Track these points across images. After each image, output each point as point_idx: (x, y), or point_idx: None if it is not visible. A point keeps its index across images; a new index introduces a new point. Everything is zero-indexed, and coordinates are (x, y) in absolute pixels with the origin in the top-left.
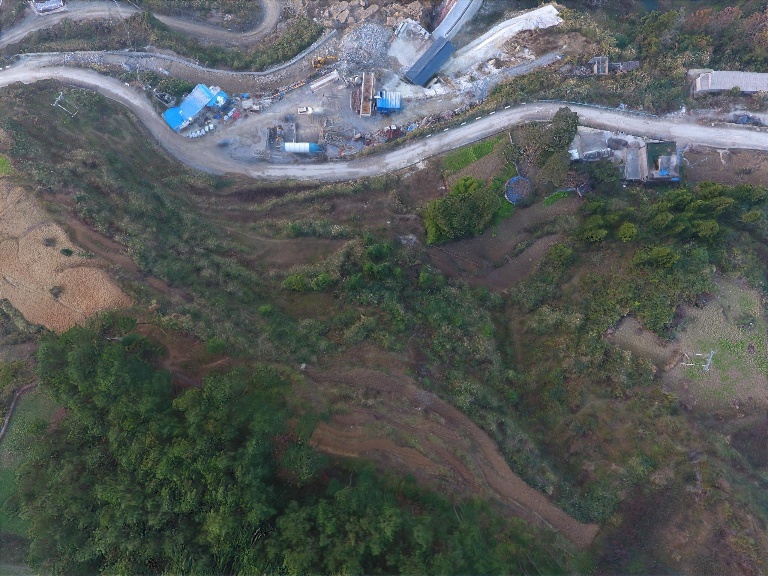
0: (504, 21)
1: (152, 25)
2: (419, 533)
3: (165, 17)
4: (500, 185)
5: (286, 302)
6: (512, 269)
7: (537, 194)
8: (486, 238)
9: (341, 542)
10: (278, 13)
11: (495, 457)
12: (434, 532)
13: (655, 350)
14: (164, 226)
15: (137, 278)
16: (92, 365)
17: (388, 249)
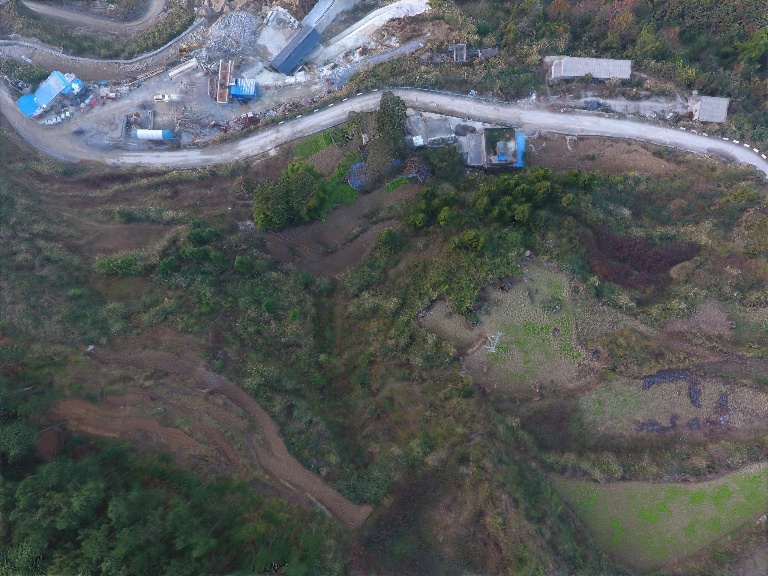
0: (376, 10)
1: (20, 13)
2: (114, 508)
3: (47, 7)
4: (344, 171)
5: (103, 286)
6: (345, 254)
7: (380, 180)
8: (325, 224)
9: (29, 516)
10: (164, 3)
11: (274, 438)
12: (138, 507)
13: (462, 333)
14: None
15: None
16: None
17: (212, 234)
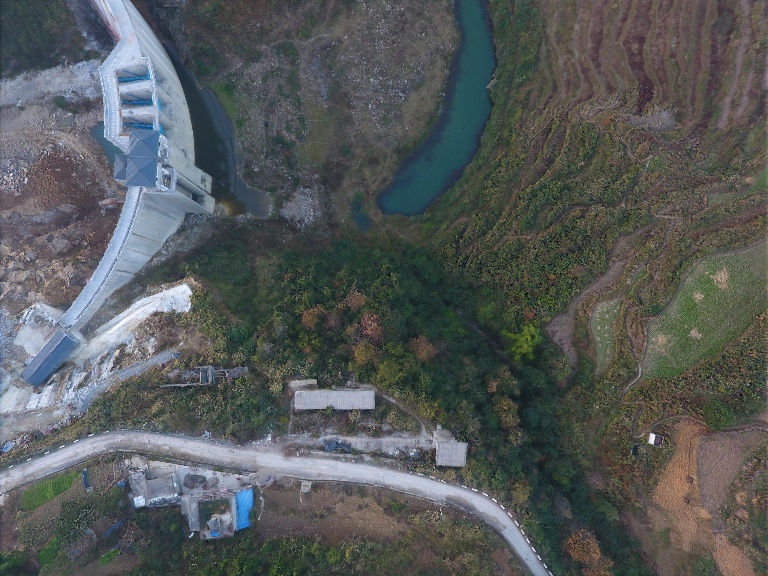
0: (143, 298)
1: None
2: None
3: None
4: None
5: None
6: None
7: (97, 548)
8: None
9: None
10: None
11: None
12: None
13: None
14: None
15: None
16: None
17: None
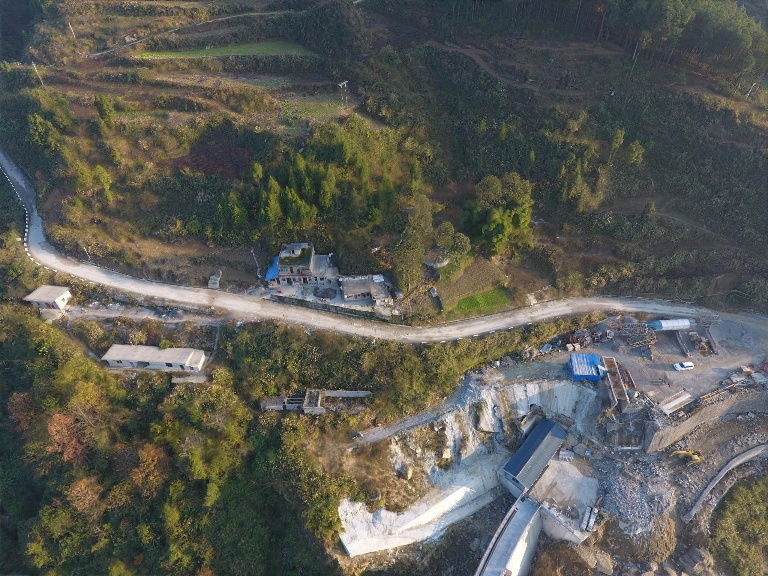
0: None
1: None
2: None
3: None
4: None
5: None
6: (447, 194)
7: None
8: None
9: None
10: None
11: (482, 63)
12: None
13: (360, 118)
14: (767, 211)
15: (762, 144)
16: (755, 44)
17: None
